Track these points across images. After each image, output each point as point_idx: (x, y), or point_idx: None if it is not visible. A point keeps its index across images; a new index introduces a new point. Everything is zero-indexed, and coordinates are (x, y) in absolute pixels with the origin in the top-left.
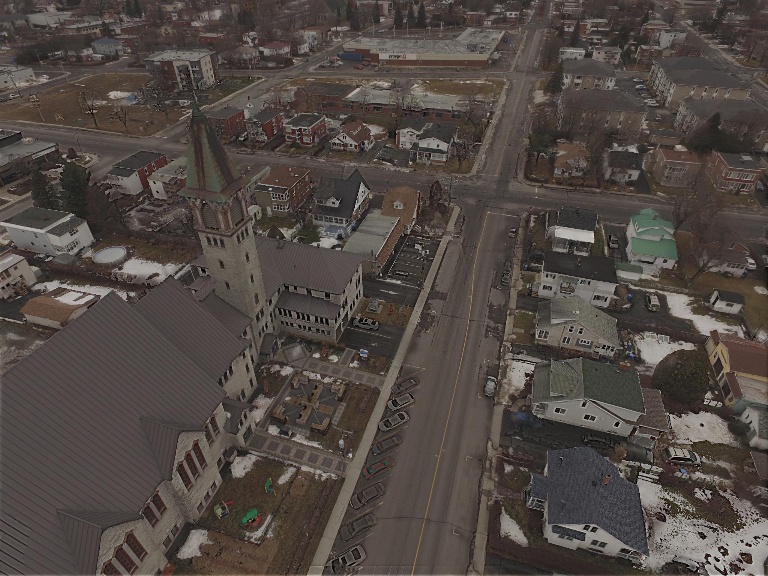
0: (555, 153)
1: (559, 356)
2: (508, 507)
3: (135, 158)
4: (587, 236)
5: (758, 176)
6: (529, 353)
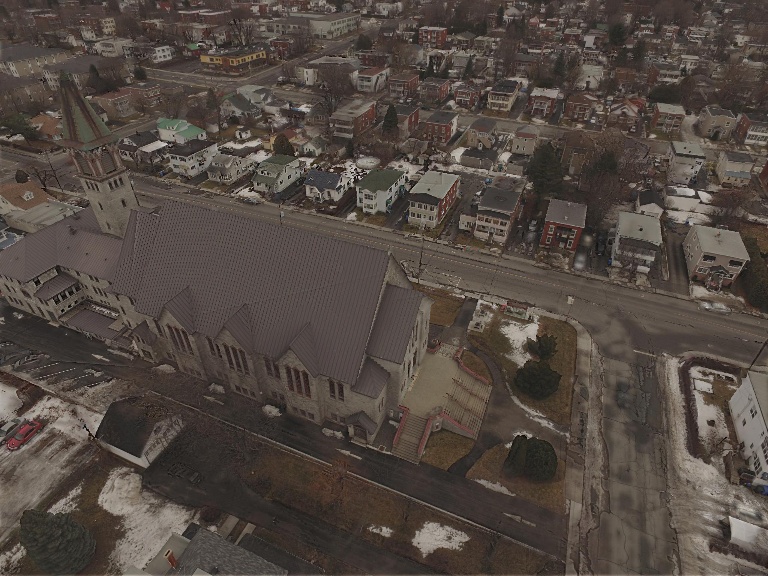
0: (37, 127)
1: (244, 181)
2: (319, 208)
3: None
4: (160, 144)
5: (160, 90)
6: (235, 188)
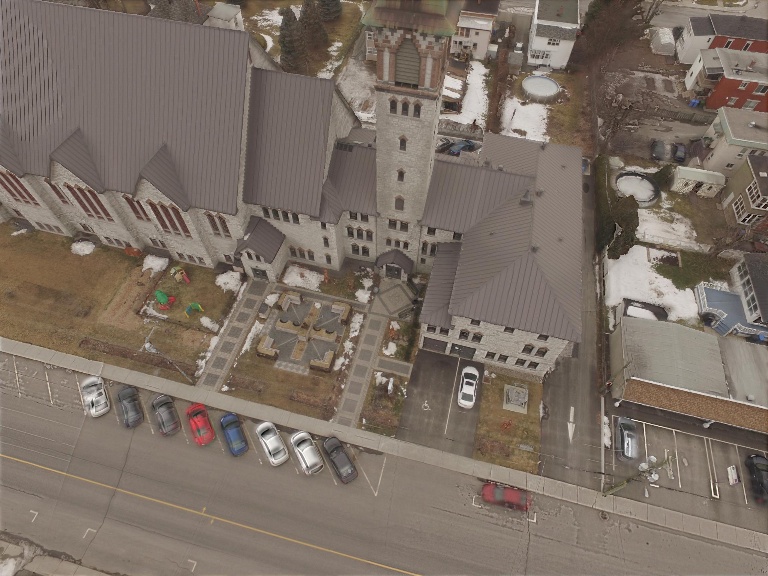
0: None
1: None
2: None
3: (740, 20)
4: None
5: None
6: None
